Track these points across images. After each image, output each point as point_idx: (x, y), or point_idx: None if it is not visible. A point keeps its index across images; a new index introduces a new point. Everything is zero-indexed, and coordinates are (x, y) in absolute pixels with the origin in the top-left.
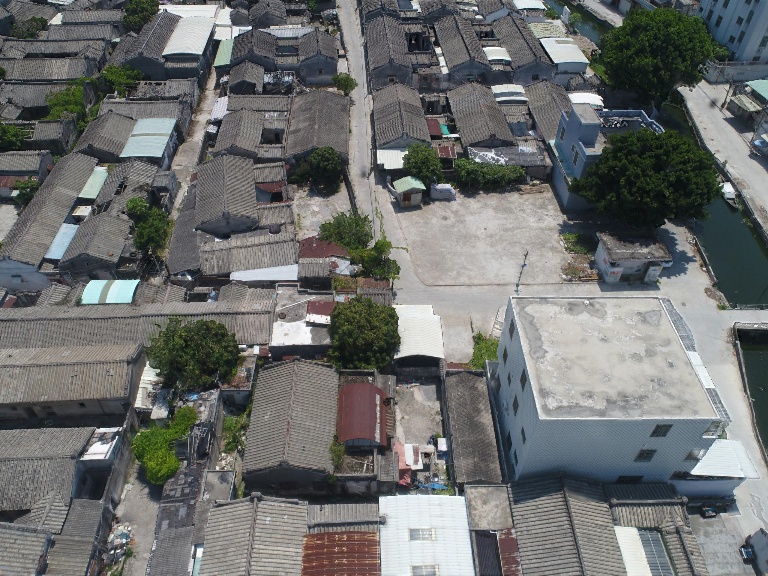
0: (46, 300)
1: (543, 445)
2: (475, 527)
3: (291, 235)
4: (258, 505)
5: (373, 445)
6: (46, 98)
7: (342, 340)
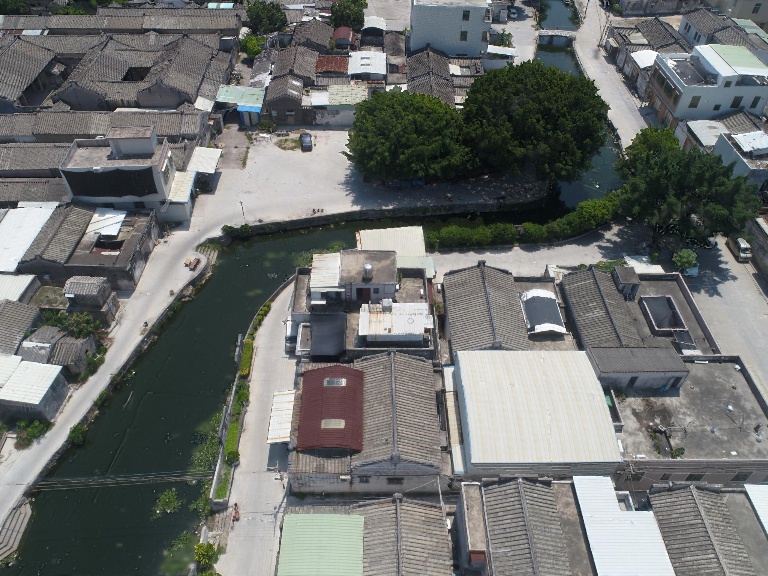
0: (190, 6)
1: (419, 26)
2: (390, 63)
3: None
4: (298, 47)
5: (348, 44)
6: None
7: (336, 15)
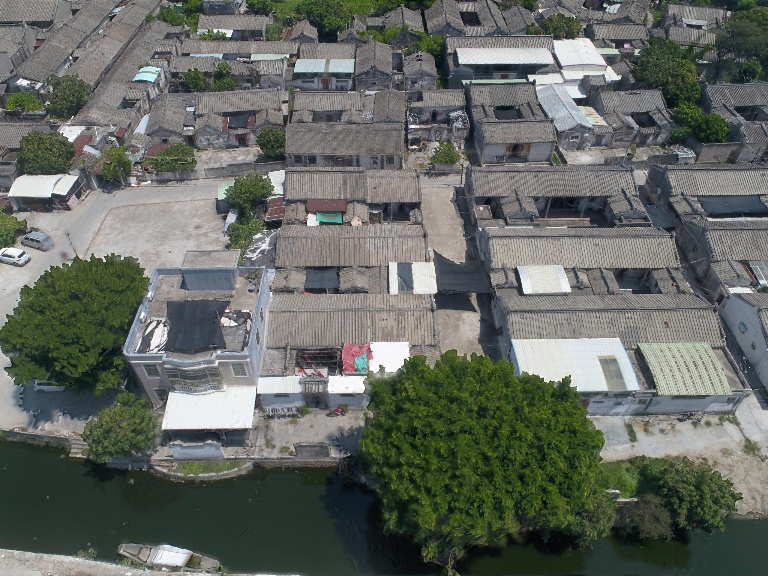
0: None
1: None
2: None
3: (172, 128)
4: None
5: None
6: (391, 26)
7: None
